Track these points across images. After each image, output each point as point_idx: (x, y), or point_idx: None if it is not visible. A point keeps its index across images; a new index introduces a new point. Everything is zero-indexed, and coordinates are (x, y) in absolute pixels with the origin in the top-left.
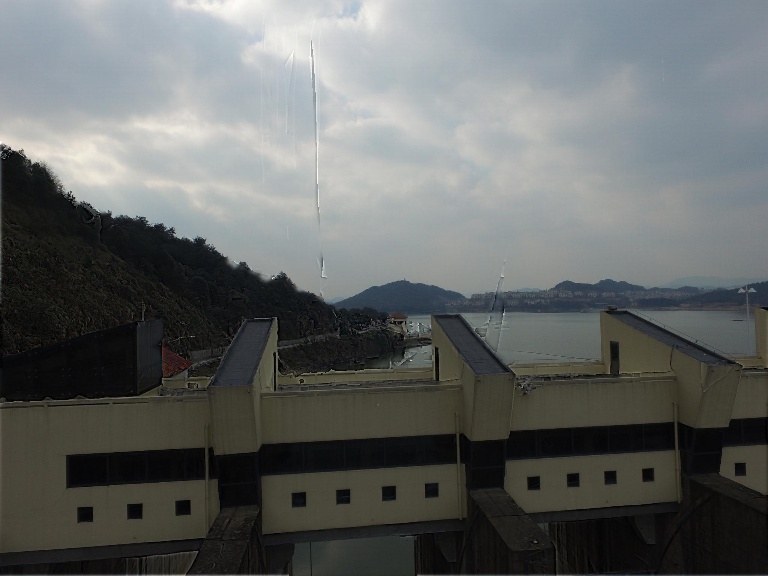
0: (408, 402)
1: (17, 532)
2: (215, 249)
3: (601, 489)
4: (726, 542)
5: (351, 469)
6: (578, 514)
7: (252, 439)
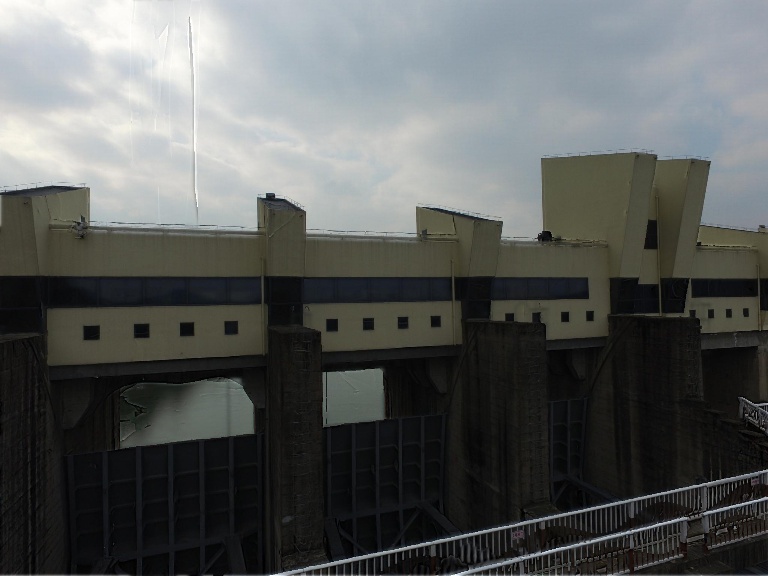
0: None
1: None
2: None
3: (176, 341)
4: (273, 376)
5: None
6: (150, 367)
7: None
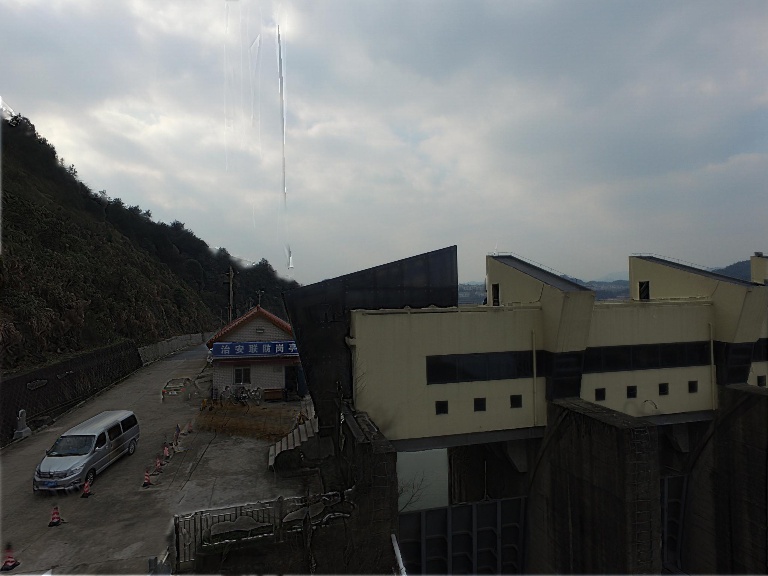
0: (676, 314)
1: (388, 423)
2: (193, 234)
3: None
4: None
5: (636, 369)
6: None
7: (584, 339)
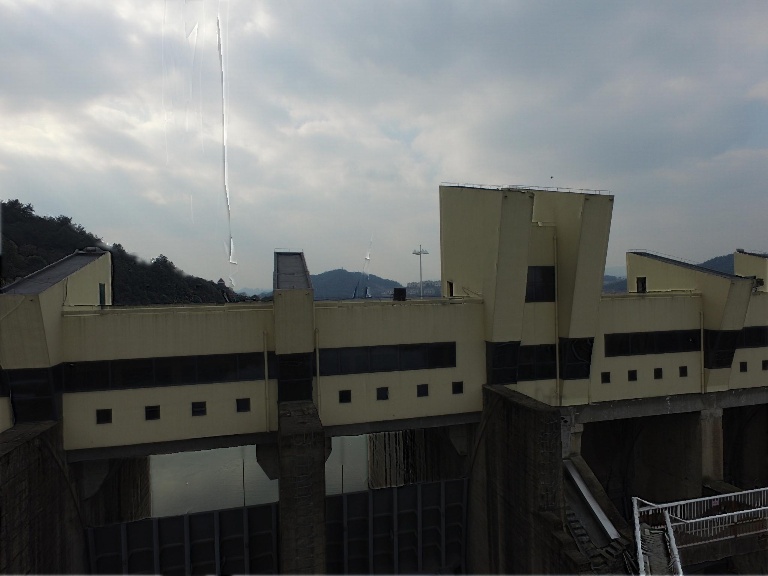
0: None
1: None
2: (83, 229)
3: None
4: None
5: None
6: None
7: None
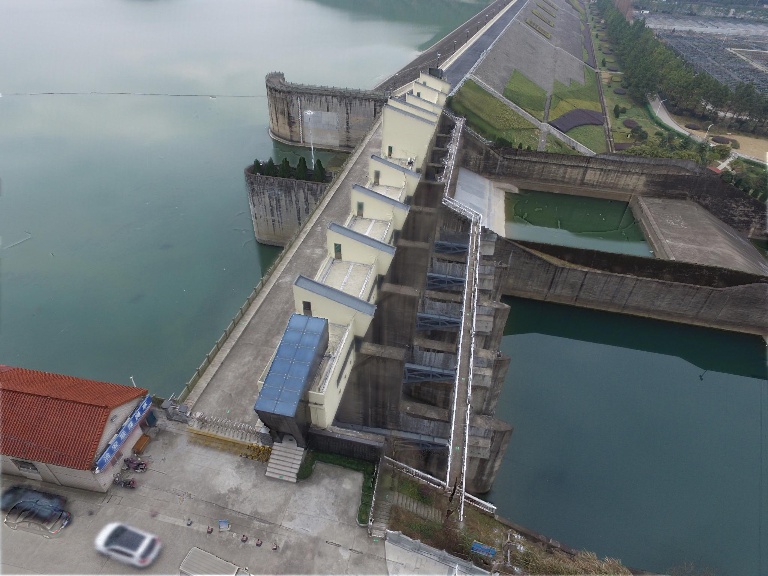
0: None
1: None
2: None
3: None
4: (409, 258)
5: None
6: None
7: None
